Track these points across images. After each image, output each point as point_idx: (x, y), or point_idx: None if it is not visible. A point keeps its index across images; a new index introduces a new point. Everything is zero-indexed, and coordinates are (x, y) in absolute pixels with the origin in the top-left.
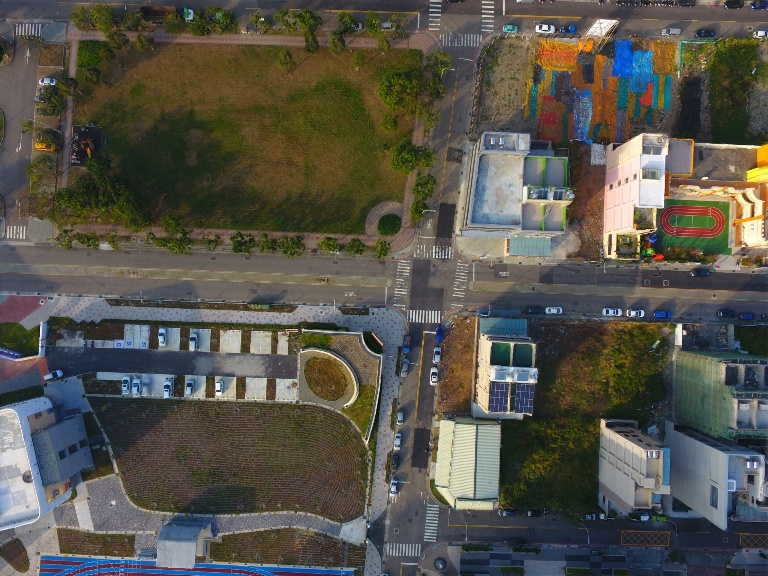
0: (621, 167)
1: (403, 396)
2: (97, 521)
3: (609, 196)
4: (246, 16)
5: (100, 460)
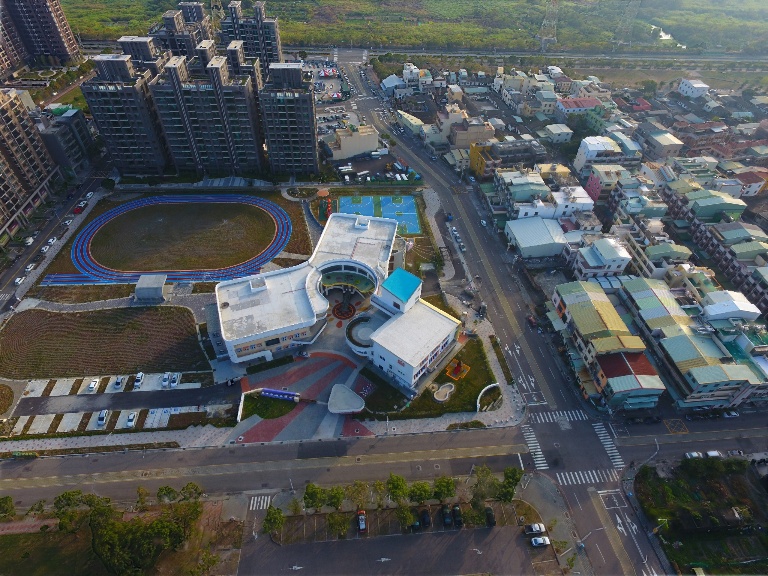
0: None
1: None
2: None
3: None
4: None
5: None
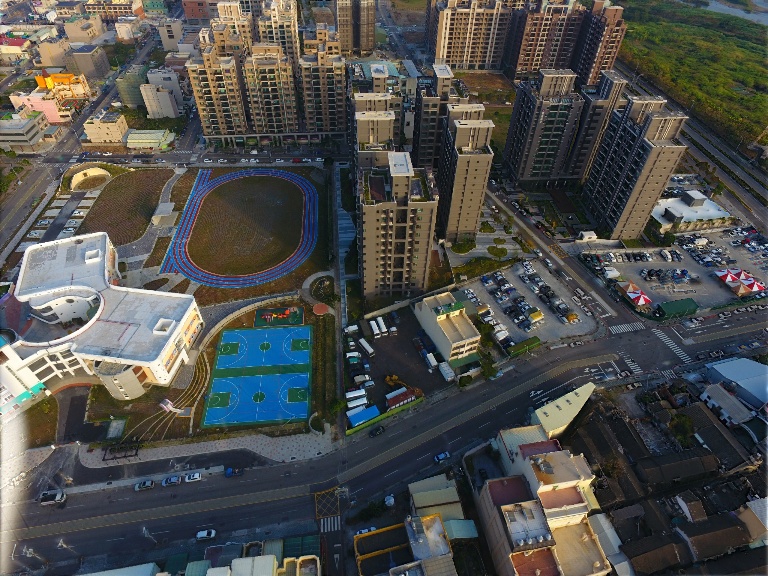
0: None
1: None
2: None
3: None
4: None
5: None
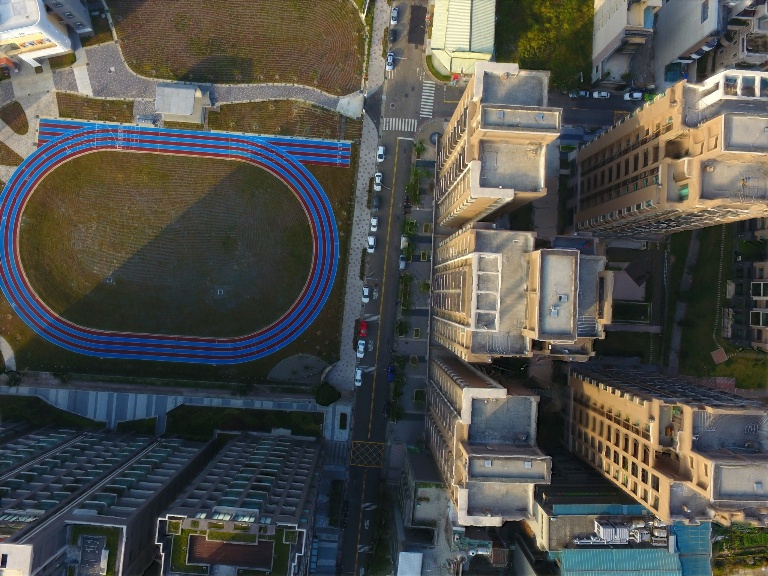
0: None
1: None
2: (96, 87)
3: None
4: None
5: (99, 26)
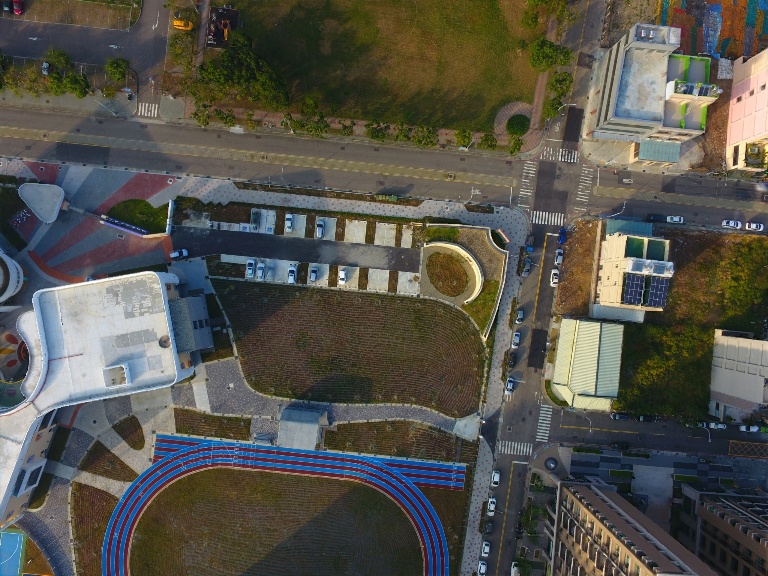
0: (755, 76)
1: (523, 296)
2: (214, 403)
3: (736, 109)
4: None
5: (220, 342)
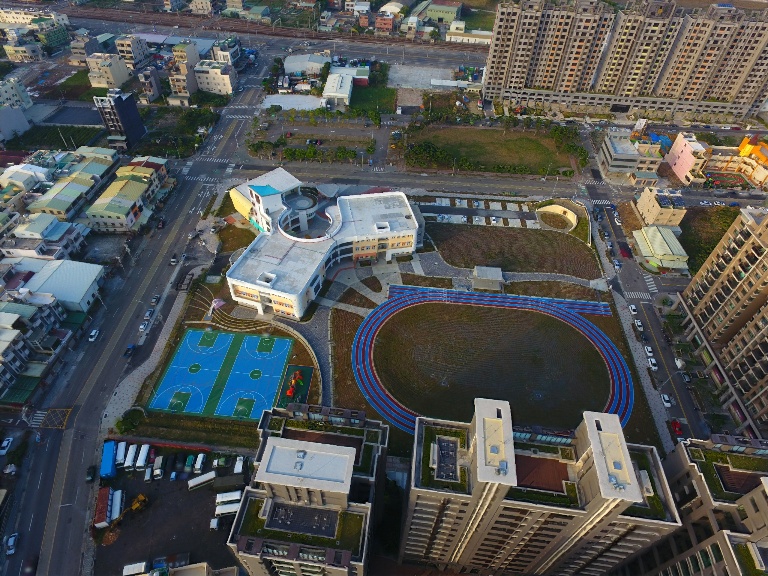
0: (676, 152)
1: None
2: (426, 271)
3: (676, 167)
4: (480, 123)
5: (426, 245)
